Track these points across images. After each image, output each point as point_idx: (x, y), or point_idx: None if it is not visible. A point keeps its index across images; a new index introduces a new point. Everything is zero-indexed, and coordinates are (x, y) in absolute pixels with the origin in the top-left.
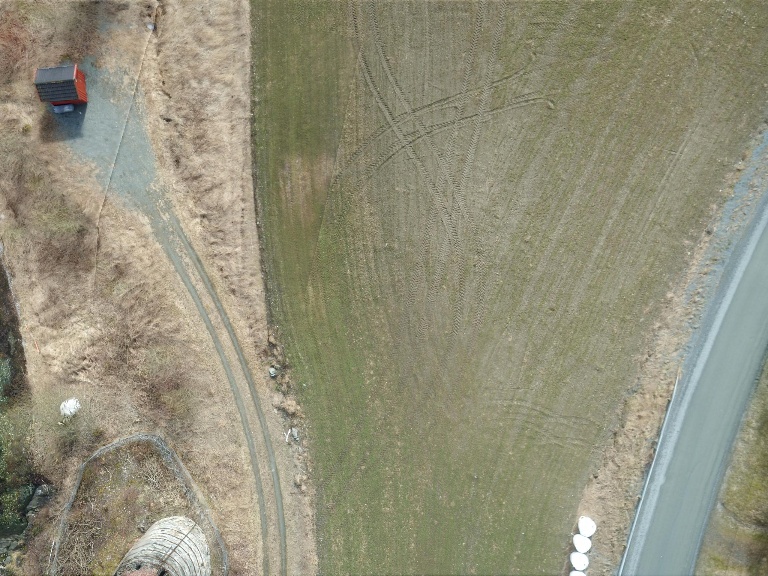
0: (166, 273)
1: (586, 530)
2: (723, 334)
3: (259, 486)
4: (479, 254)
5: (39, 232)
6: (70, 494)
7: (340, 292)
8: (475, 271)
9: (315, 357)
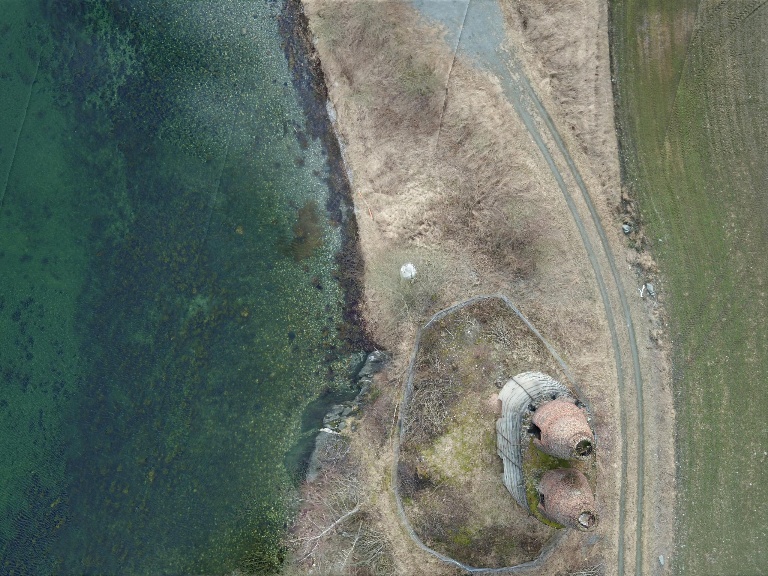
0: (517, 132)
1: None
2: None
3: (615, 341)
4: None
5: (376, 98)
6: (408, 358)
7: (699, 146)
8: None
9: (672, 212)
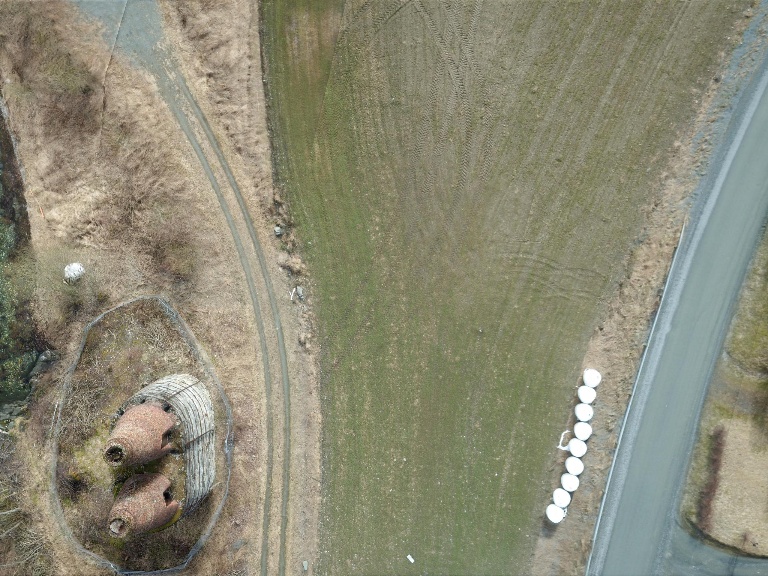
0: (172, 132)
1: (591, 380)
2: (730, 181)
3: (263, 344)
4: (486, 106)
5: (45, 95)
6: (74, 358)
7: (346, 149)
8: (482, 123)
9: (320, 214)
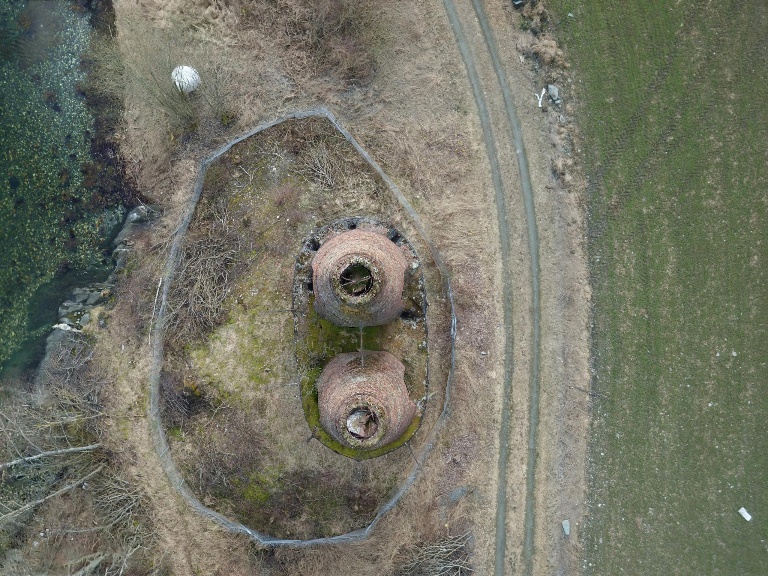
0: None
1: None
2: None
3: (496, 176)
4: None
5: None
6: (184, 213)
7: None
8: None
9: None
